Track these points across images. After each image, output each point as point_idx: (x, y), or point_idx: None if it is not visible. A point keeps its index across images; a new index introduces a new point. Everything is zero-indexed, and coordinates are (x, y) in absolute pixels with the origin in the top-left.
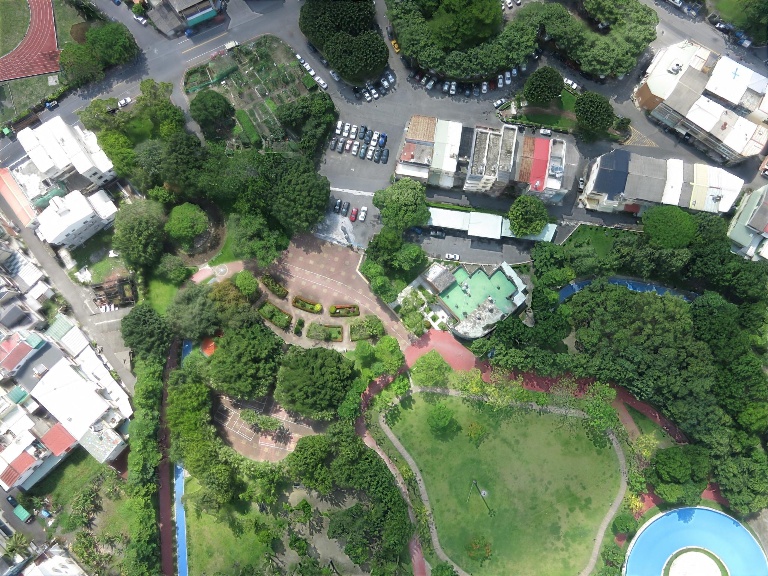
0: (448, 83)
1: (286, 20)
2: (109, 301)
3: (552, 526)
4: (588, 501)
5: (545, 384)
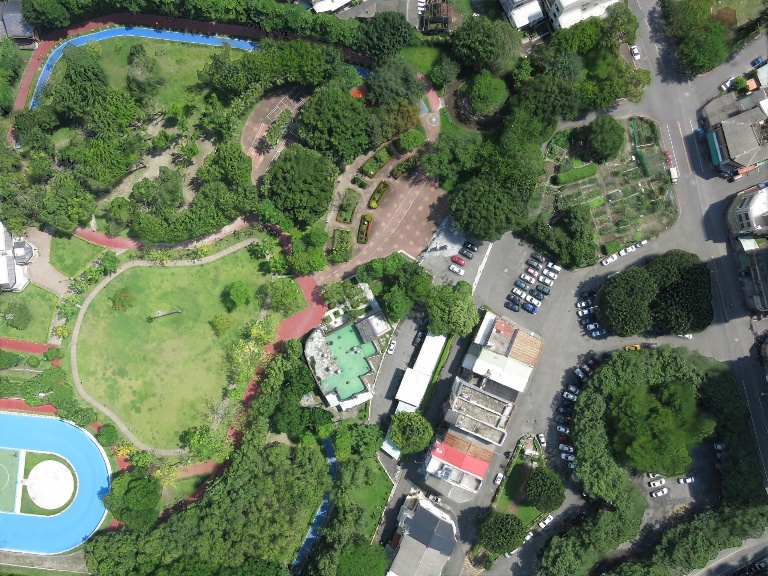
0: (577, 392)
1: (691, 239)
2: (429, 7)
3: (125, 371)
4: (138, 410)
5: None
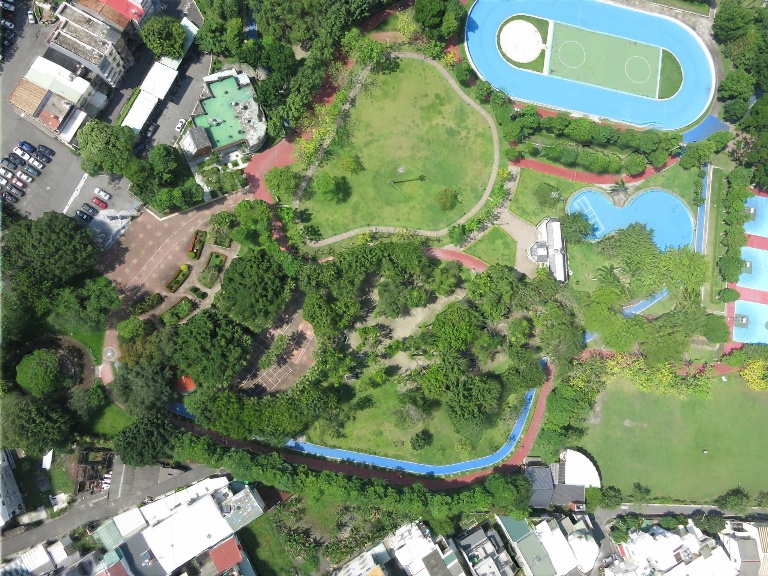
0: None
1: None
2: (99, 478)
3: (448, 133)
4: (437, 97)
5: (330, 91)
